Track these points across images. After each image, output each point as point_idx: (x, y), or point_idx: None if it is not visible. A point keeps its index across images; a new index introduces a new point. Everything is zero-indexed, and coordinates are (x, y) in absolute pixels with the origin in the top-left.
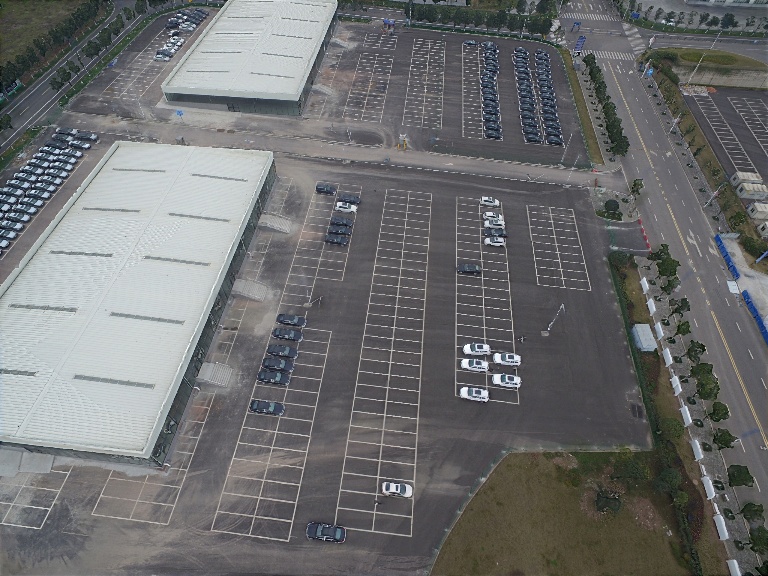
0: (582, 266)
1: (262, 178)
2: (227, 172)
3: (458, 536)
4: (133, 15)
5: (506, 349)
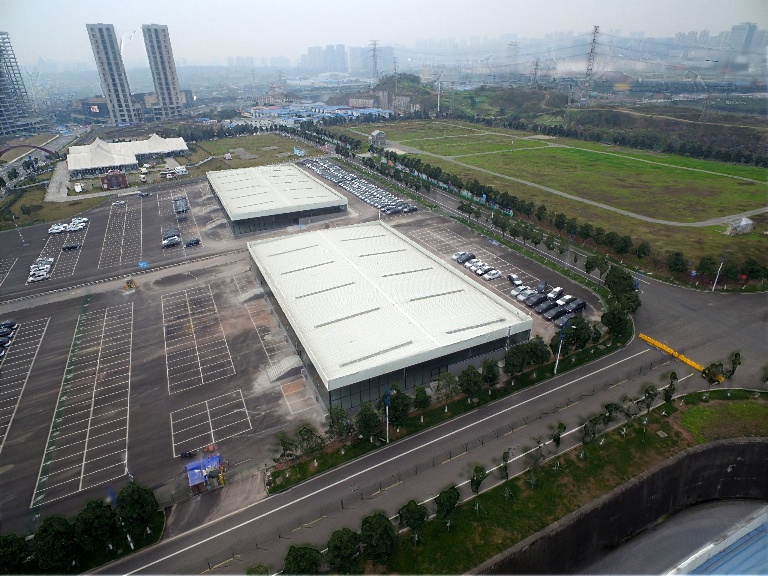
0: None
1: None
2: (254, 206)
3: (94, 205)
4: None
5: None
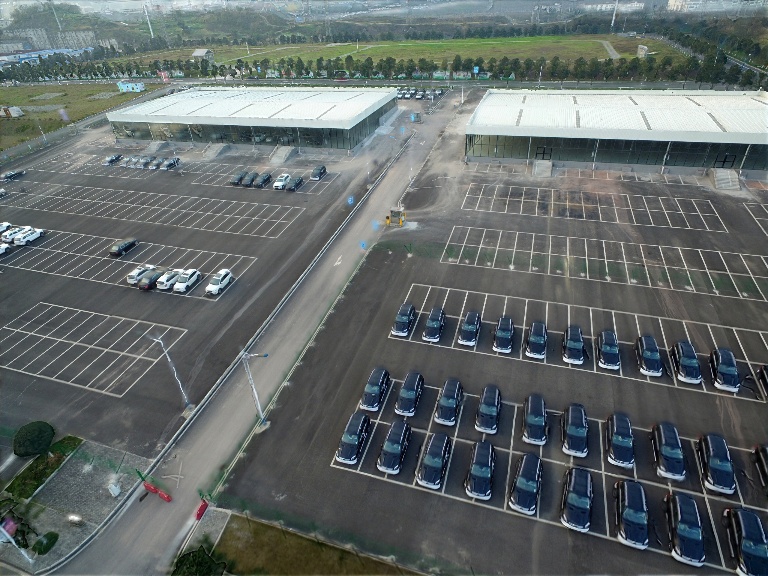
0: (5, 361)
1: (313, 122)
2: (332, 113)
3: None
4: (655, 75)
5: (7, 259)
